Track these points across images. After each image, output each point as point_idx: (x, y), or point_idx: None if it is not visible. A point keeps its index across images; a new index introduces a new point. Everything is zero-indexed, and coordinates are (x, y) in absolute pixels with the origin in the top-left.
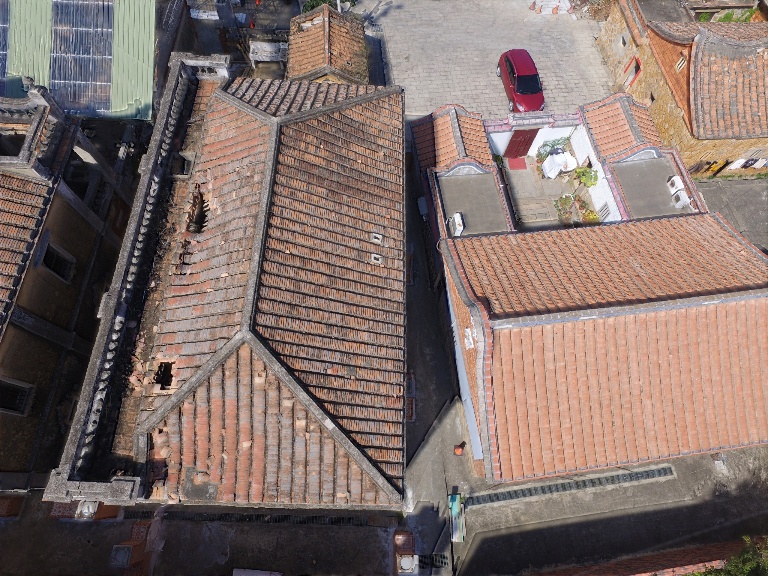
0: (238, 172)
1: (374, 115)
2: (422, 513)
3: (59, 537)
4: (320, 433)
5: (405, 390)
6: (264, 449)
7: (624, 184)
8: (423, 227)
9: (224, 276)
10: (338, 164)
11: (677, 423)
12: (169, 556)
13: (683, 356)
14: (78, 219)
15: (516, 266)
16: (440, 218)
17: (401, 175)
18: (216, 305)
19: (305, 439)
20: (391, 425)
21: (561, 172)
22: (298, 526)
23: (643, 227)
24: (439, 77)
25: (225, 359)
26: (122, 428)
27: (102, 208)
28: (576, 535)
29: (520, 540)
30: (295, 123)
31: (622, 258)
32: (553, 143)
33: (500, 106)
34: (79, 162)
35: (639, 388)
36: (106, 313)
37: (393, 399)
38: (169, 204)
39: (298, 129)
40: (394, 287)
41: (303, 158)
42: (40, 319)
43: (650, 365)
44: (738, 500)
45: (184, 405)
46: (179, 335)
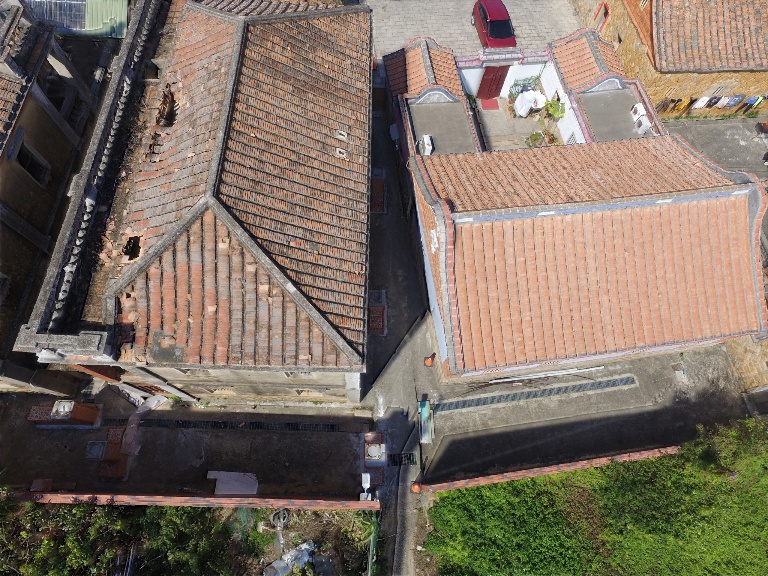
0: (207, 68)
1: (342, 28)
2: (392, 417)
3: (36, 443)
4: (282, 298)
5: (367, 270)
6: (229, 314)
7: (589, 112)
8: (396, 159)
9: (191, 156)
10: (305, 66)
11: (633, 318)
12: (145, 460)
13: (638, 254)
14: (53, 127)
15: (481, 176)
16: (410, 139)
17: (368, 84)
18: (182, 180)
19: (268, 304)
20: (352, 297)
21: (532, 110)
22: (272, 432)
23: (605, 146)
24: (415, 25)
25: (190, 224)
26: (92, 299)
27: (78, 125)
28: (541, 437)
29: (487, 442)
30: (262, 24)
31: (583, 170)
32: (524, 83)
33: (474, 52)
34: (55, 77)
35: (596, 284)
36: (76, 191)
37: (355, 275)
38: (141, 105)
39: (265, 30)
40: (358, 179)
41: (270, 56)
42: (14, 213)
43: (607, 262)
44: (697, 405)
45: (151, 270)
46: (147, 211)
